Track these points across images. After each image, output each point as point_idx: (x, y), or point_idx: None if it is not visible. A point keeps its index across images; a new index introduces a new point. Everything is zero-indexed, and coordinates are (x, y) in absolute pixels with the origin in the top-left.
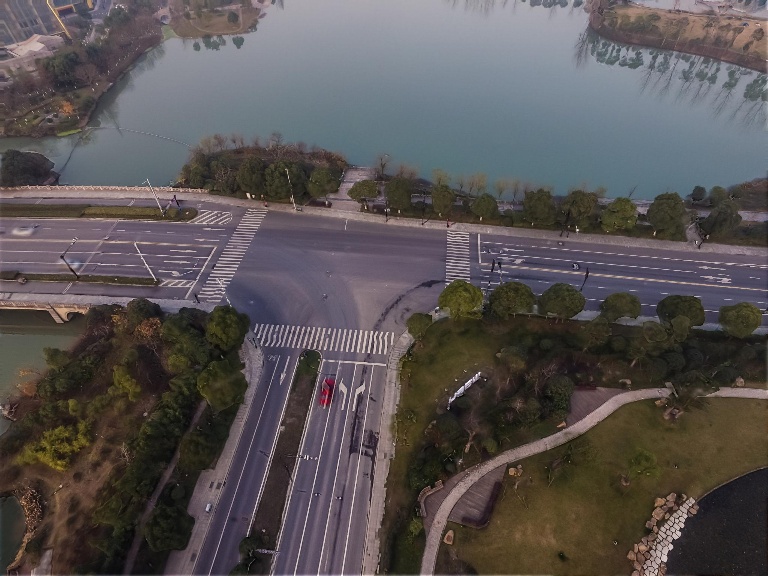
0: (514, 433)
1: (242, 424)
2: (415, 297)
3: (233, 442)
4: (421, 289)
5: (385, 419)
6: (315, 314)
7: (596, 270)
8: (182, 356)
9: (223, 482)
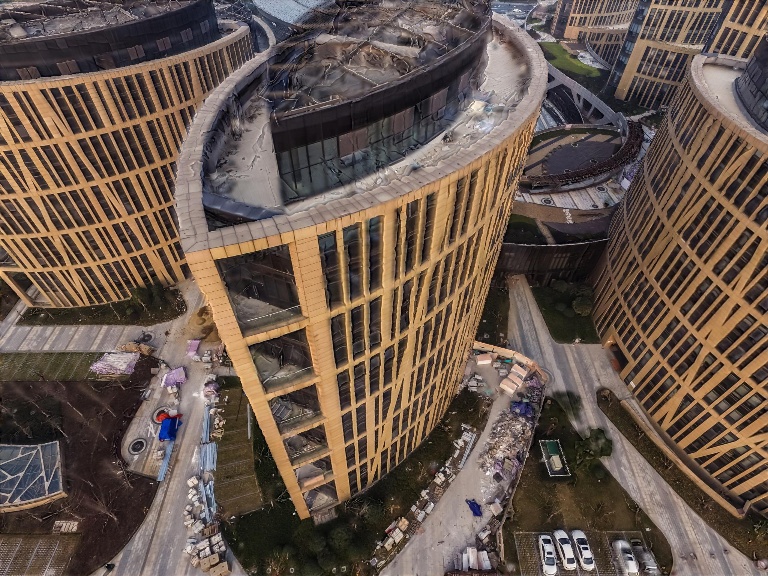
0: None
1: None
2: None
3: None
4: None
5: None
6: None
7: None
8: (118, 0)
9: None
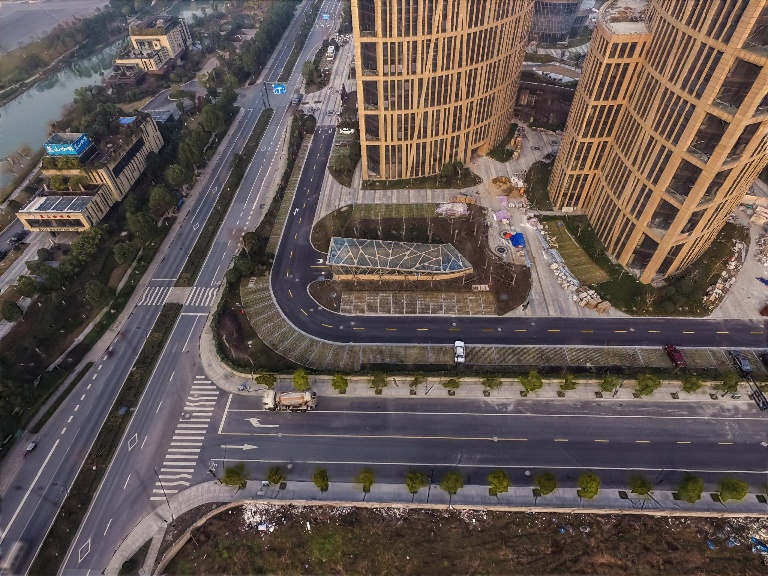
0: None
1: None
2: None
3: (304, 2)
4: None
5: None
6: None
7: None
8: None
9: None
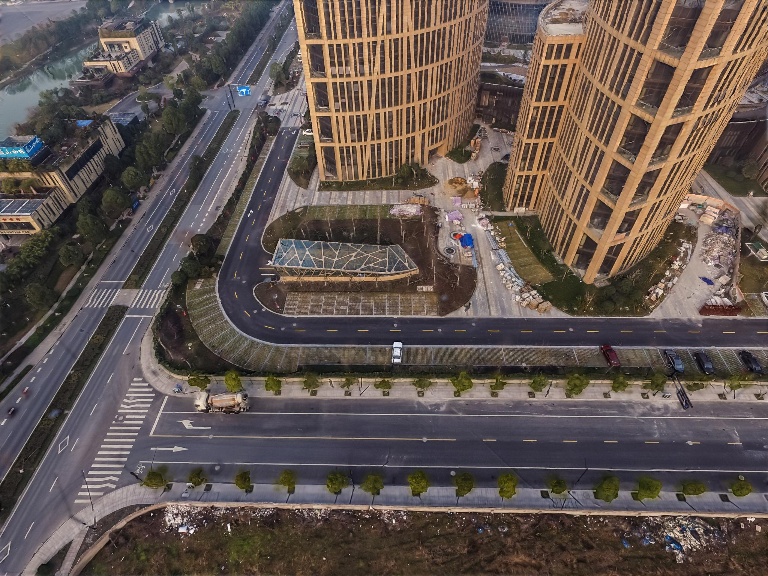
0: None
1: (283, 2)
2: None
3: None
4: None
5: None
6: None
7: None
8: None
9: (280, 7)
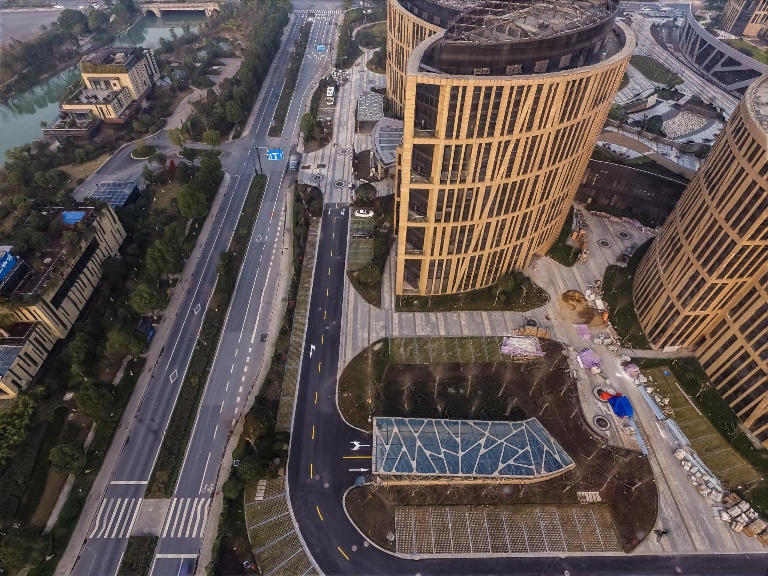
0: (381, 18)
1: (292, 22)
2: None
3: (290, 24)
4: None
5: None
6: (311, 8)
7: None
8: (269, 0)
9: None
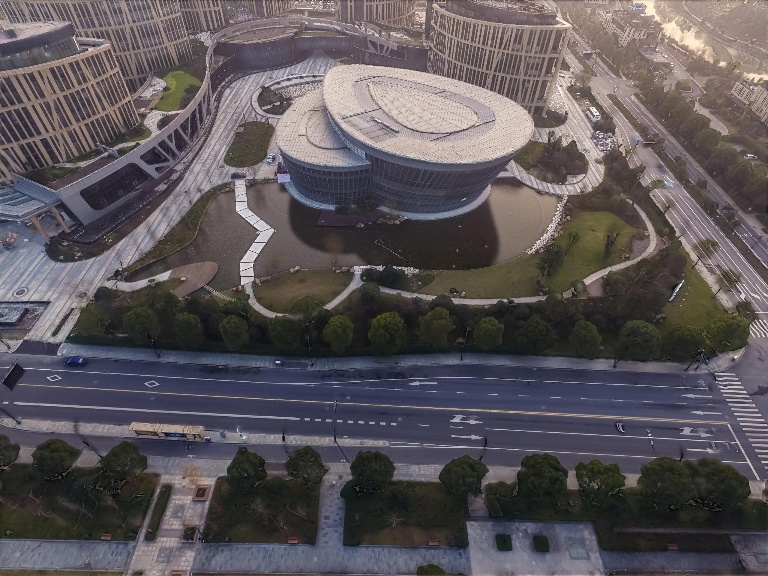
0: None
1: None
2: (764, 373)
3: None
4: (766, 383)
5: (713, 280)
6: None
7: (597, 423)
8: None
9: None
